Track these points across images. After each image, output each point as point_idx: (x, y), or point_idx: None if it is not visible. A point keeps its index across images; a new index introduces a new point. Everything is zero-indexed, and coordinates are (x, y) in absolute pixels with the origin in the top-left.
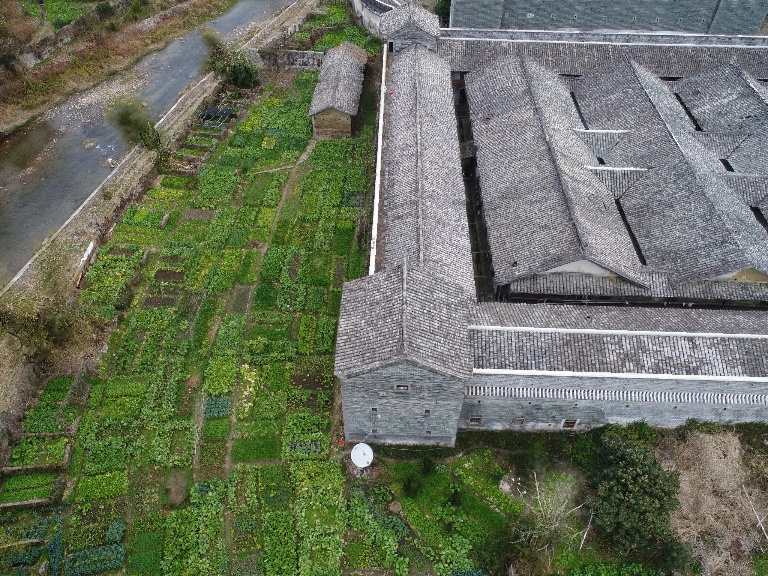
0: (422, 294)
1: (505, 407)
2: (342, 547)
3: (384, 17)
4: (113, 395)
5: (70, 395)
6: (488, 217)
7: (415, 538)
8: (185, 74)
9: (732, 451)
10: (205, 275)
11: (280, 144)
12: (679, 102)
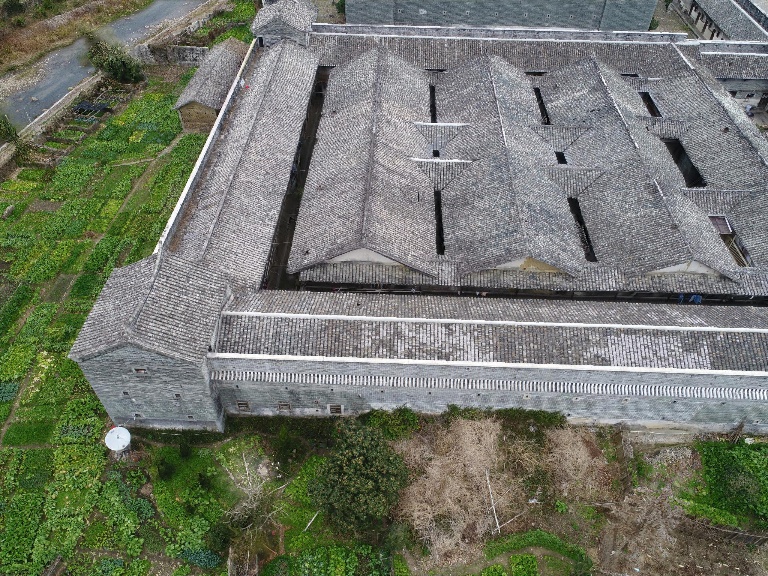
0: (175, 280)
1: (265, 392)
2: (83, 528)
3: (259, 12)
4: None
5: None
6: (302, 207)
7: (158, 520)
8: (84, 70)
9: (487, 436)
10: (32, 265)
11: (147, 138)
12: (537, 96)
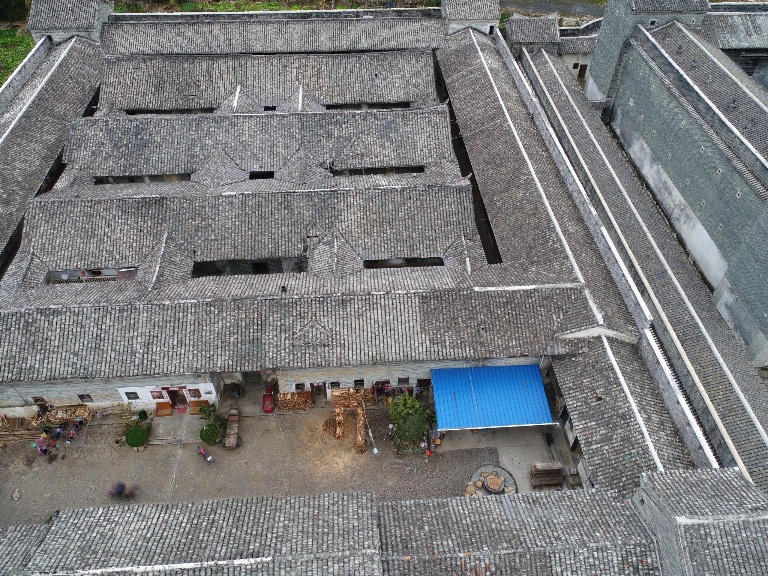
0: (80, 6)
1: None
2: None
3: None
4: None
5: (123, 3)
6: None
7: None
8: None
9: None
10: None
11: None
12: None
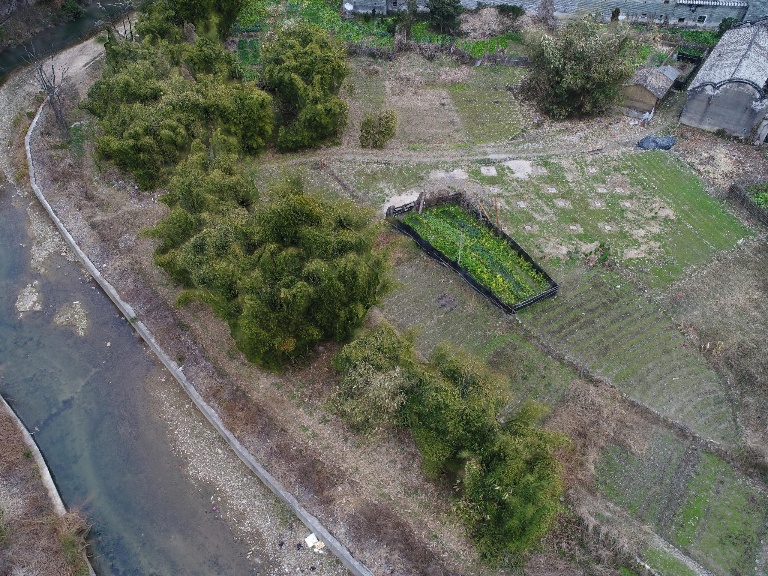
0: None
1: None
2: None
3: None
4: (251, 4)
5: None
6: None
7: None
8: None
9: (492, 12)
10: None
11: None
12: None
